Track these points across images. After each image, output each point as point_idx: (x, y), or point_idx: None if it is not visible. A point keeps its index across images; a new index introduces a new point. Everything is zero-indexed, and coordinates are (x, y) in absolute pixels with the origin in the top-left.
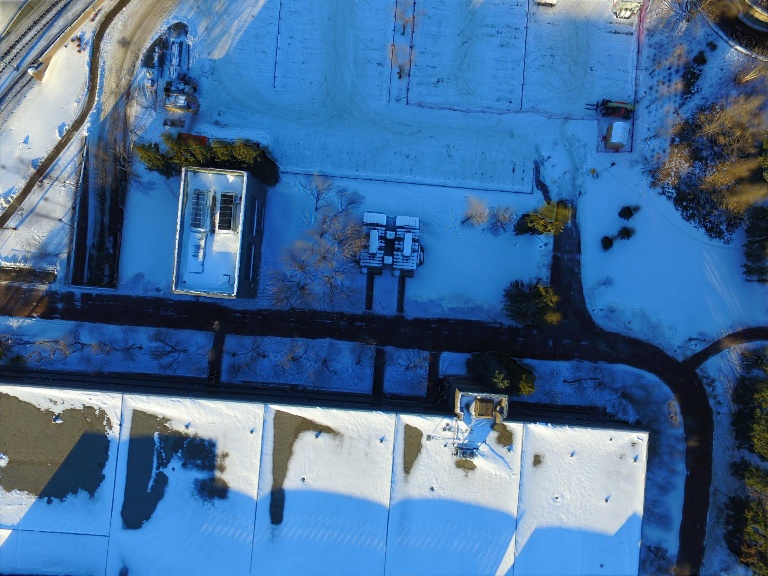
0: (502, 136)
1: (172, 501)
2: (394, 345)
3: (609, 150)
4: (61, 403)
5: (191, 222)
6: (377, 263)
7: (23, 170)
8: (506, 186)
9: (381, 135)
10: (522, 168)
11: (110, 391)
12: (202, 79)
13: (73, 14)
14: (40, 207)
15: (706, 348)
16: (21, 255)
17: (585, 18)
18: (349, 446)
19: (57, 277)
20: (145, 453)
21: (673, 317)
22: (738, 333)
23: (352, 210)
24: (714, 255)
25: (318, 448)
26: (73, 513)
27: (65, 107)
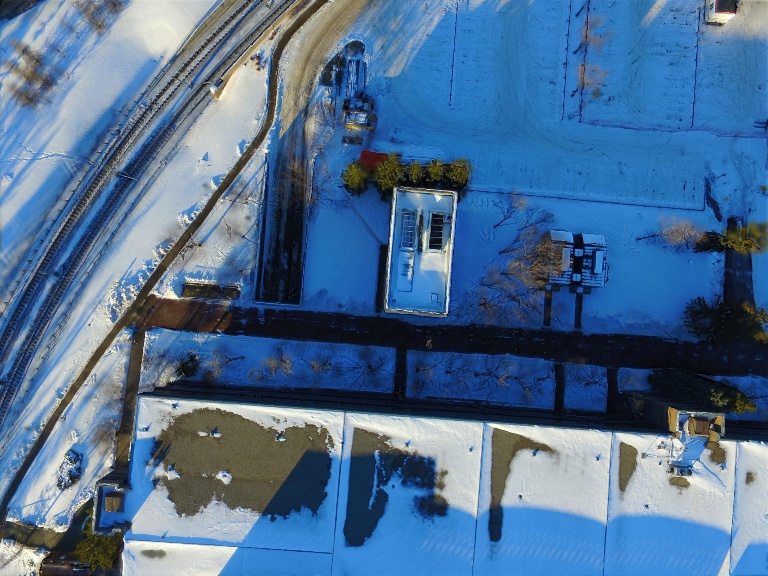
0: (673, 154)
1: (393, 518)
2: (572, 361)
3: None
4: (284, 421)
5: (403, 241)
6: (566, 280)
7: (204, 187)
8: (677, 203)
9: (554, 152)
10: (693, 185)
11: (332, 409)
12: (379, 97)
13: (244, 32)
14: (223, 224)
15: None
16: (205, 271)
17: (753, 37)
18: (565, 464)
19: (240, 293)
20: (366, 471)
21: None
22: None
23: (541, 228)
24: None
25: (535, 466)
26: (296, 530)
27: (245, 124)
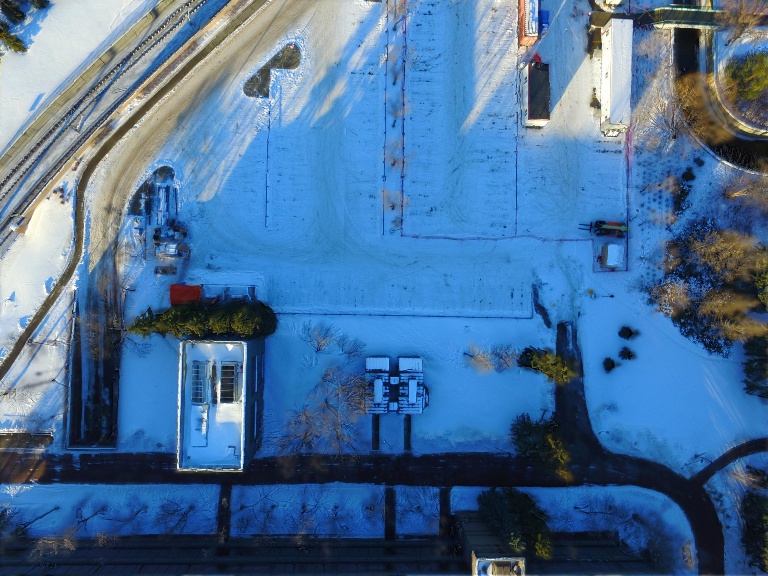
0: (498, 262)
1: None
2: (403, 483)
3: (605, 269)
4: None
5: (192, 397)
6: (382, 410)
7: (11, 330)
8: (505, 312)
9: (377, 268)
10: (520, 293)
11: None
12: (192, 223)
13: (53, 159)
14: (31, 368)
15: (712, 463)
16: (14, 420)
17: (574, 138)
18: None
19: (53, 439)
20: None
21: (678, 435)
22: (742, 446)
23: (354, 358)
24: (714, 370)
25: None
26: None
27: (51, 261)
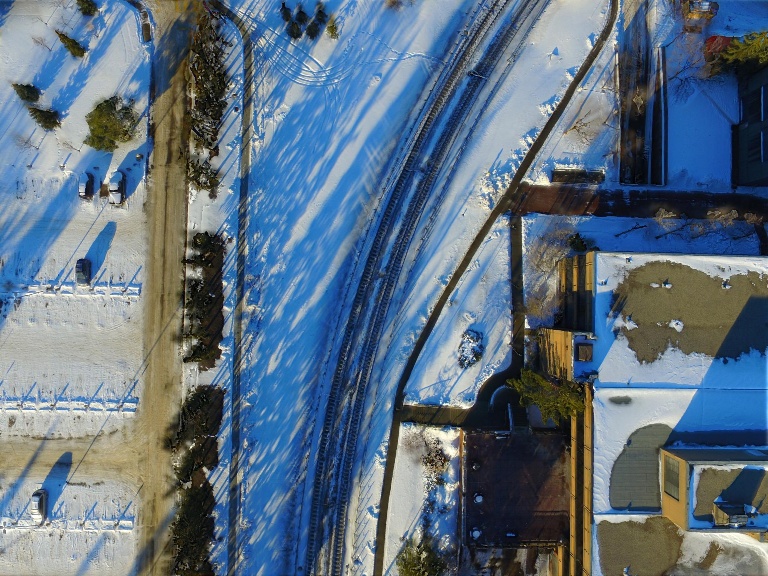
0: None
1: None
2: None
3: None
4: (728, 270)
5: None
6: None
7: (560, 79)
8: None
9: None
10: None
11: None
12: None
13: None
14: (583, 112)
15: None
16: (572, 157)
17: None
18: None
19: (605, 177)
20: None
21: None
22: None
23: None
24: None
25: None
26: (748, 371)
27: (591, 18)
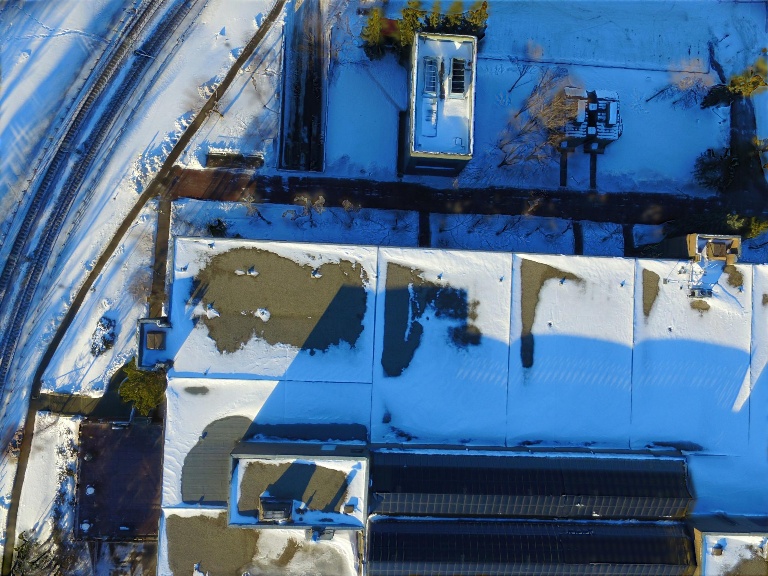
0: (677, 19)
1: (428, 349)
2: (589, 219)
3: None
4: (319, 258)
5: (426, 86)
6: (582, 134)
7: (223, 60)
8: (683, 67)
9: (563, 21)
10: (697, 49)
11: (366, 245)
12: None
13: None
14: (243, 95)
15: None
16: (228, 141)
17: None
18: (592, 291)
19: (264, 162)
20: (401, 304)
21: None
22: None
23: (555, 84)
24: None
25: (563, 294)
26: (335, 363)
27: None
